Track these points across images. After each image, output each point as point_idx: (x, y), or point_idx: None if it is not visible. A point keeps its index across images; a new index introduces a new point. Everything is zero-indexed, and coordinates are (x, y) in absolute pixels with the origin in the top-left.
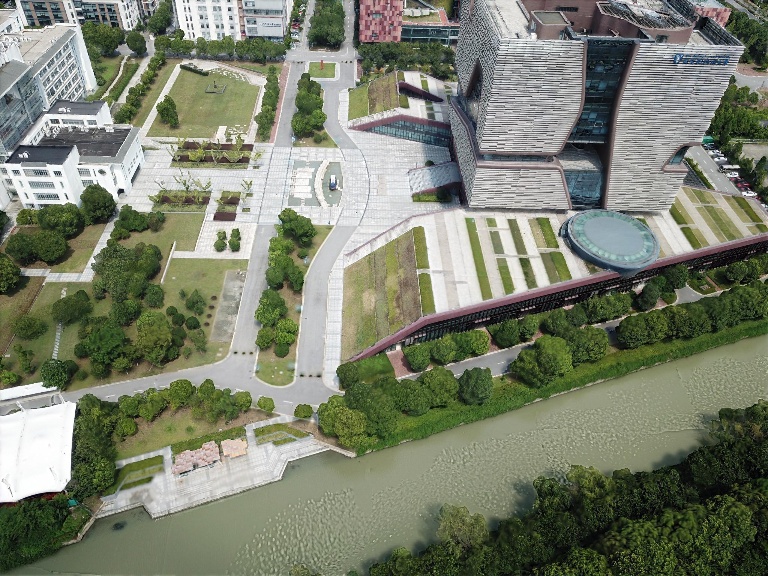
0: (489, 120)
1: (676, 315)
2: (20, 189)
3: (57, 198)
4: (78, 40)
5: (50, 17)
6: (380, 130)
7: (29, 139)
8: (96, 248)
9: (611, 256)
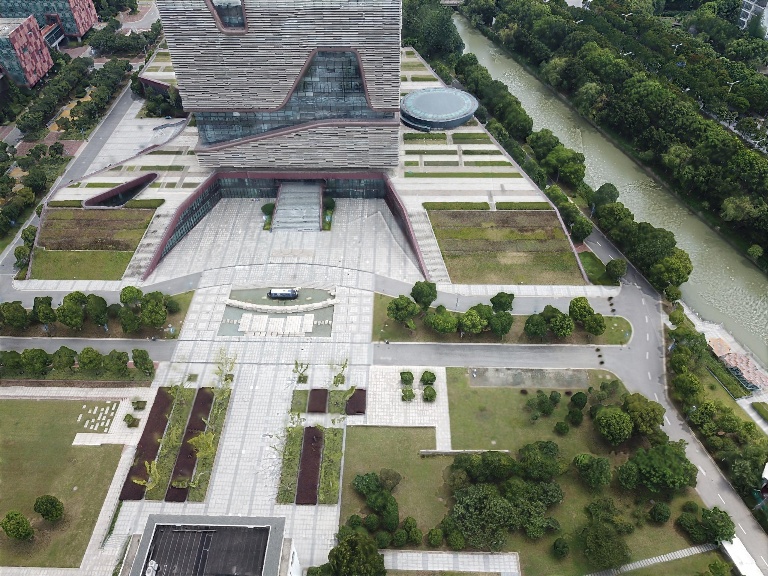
0: None
1: (517, 100)
2: None
3: None
4: None
5: None
6: (168, 247)
7: None
8: (438, 569)
9: (464, 109)
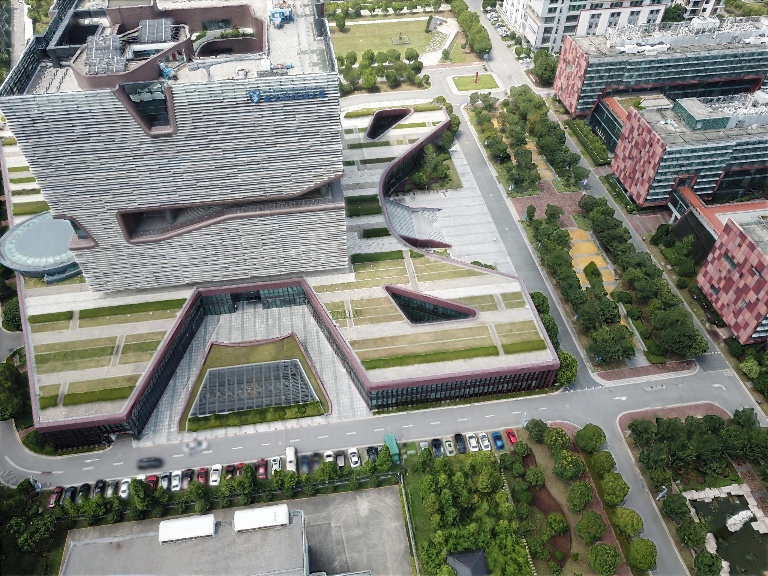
0: None
1: None
2: None
3: None
4: None
5: None
6: None
7: None
8: None
9: None
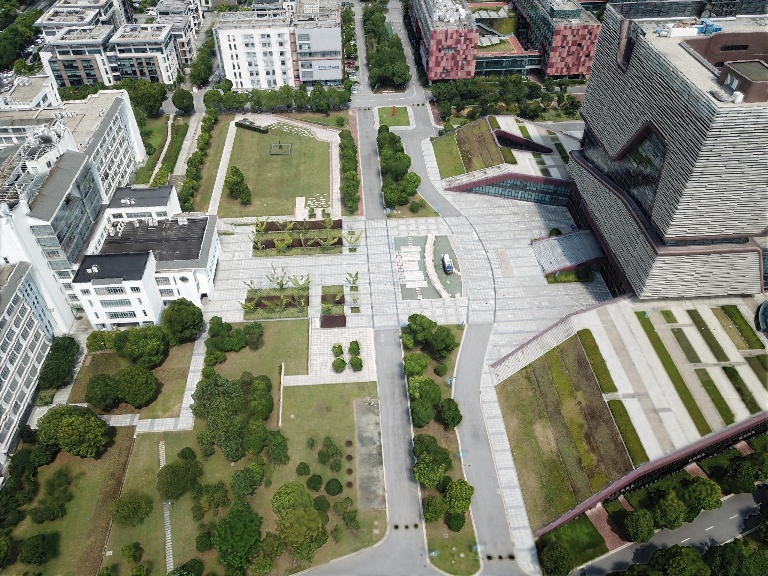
0: (683, 203)
1: None
2: (89, 309)
3: (133, 315)
4: (126, 108)
5: (82, 76)
6: (483, 190)
7: (93, 245)
8: (189, 379)
9: None
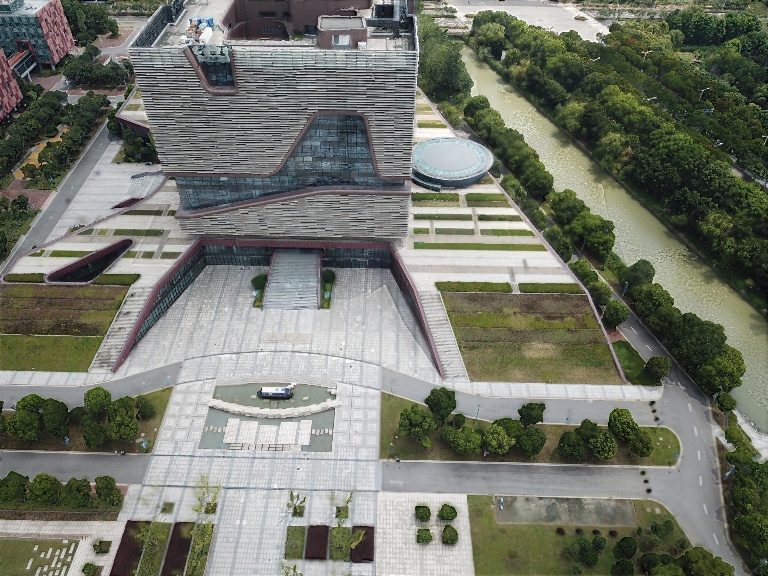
0: None
1: (535, 153)
2: None
3: None
4: None
5: None
6: (143, 330)
7: None
8: None
9: (478, 164)
